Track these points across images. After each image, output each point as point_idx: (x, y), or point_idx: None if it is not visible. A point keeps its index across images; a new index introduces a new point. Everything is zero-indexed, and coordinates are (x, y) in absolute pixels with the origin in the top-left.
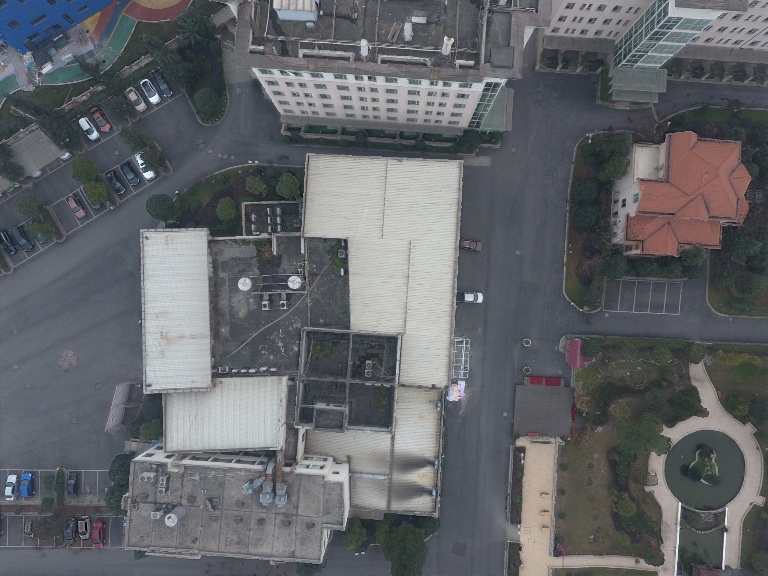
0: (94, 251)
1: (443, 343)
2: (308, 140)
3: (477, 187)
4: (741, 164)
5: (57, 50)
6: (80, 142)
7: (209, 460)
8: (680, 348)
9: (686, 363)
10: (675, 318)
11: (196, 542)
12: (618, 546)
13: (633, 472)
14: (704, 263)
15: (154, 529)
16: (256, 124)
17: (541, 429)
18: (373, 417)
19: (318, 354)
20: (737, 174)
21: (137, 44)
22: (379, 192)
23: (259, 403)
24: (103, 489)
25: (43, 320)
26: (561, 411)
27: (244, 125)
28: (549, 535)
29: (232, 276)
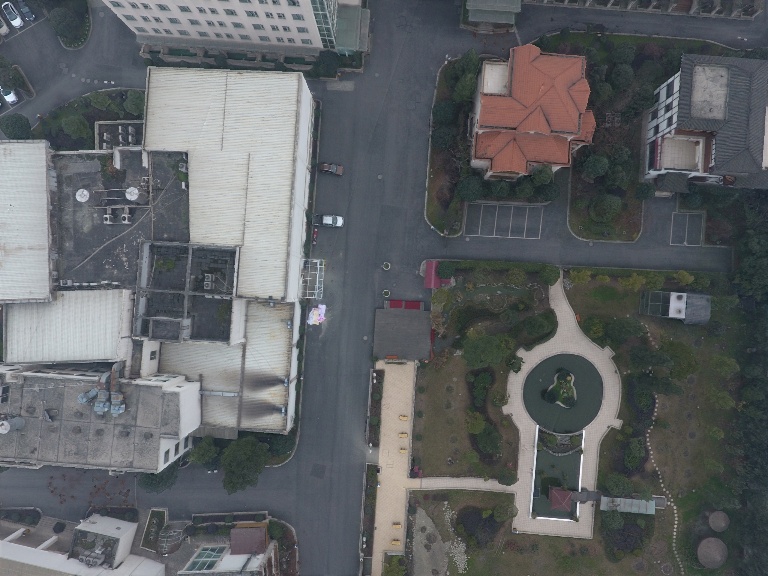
0: None
1: (280, 255)
2: (170, 64)
3: (340, 112)
4: (584, 78)
5: None
6: None
7: (51, 373)
8: (537, 271)
9: (546, 287)
10: (536, 243)
11: (35, 452)
12: (476, 468)
13: (491, 395)
14: (565, 188)
15: None
16: (119, 48)
17: (400, 352)
18: (215, 331)
19: (161, 268)
20: (577, 87)
21: None
22: (219, 105)
23: (100, 316)
24: None
25: None
26: (420, 334)
27: (107, 49)
28: (407, 457)
29: (76, 191)
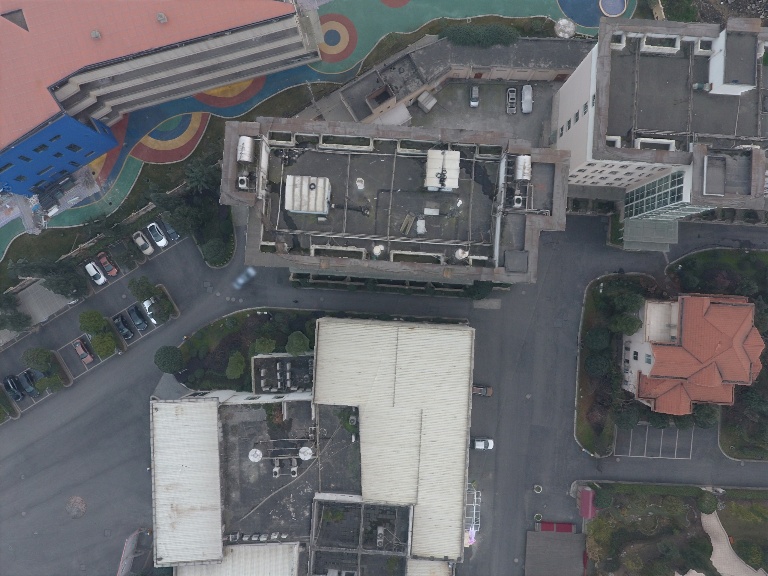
0: (102, 396)
1: (455, 514)
2: (317, 284)
3: (487, 330)
4: (754, 327)
5: (63, 192)
6: (87, 286)
7: None
8: (692, 496)
9: None
10: (687, 463)
11: None
12: None
13: None
14: None
15: None
16: (264, 267)
17: (552, 575)
18: None
19: (329, 520)
20: (750, 341)
21: (144, 187)
22: (390, 360)
23: (270, 572)
24: None
25: (51, 466)
26: (572, 558)
27: (252, 268)
28: None
29: (242, 440)
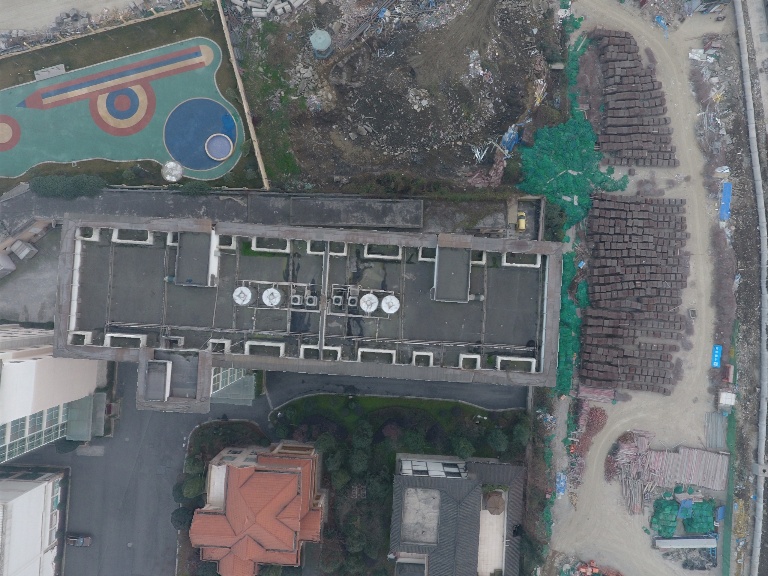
0: None
1: None
2: None
3: (90, 477)
4: (299, 495)
5: None
6: None
7: None
8: None
9: None
10: None
11: None
12: None
13: None
14: (316, 555)
15: None
16: None
17: None
18: None
19: None
20: (286, 512)
21: None
22: None
23: None
24: None
25: None
26: None
27: None
28: None
29: None
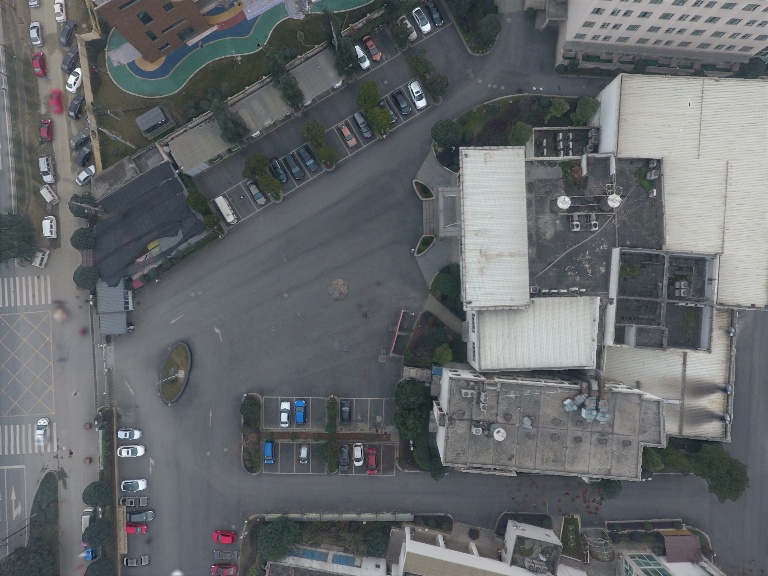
0: (363, 180)
1: (762, 263)
2: (581, 70)
3: None
4: None
5: None
6: None
7: None
8: None
9: None
10: None
11: (512, 459)
12: None
13: None
14: None
15: (470, 446)
16: (527, 54)
17: None
18: (681, 338)
19: (626, 275)
20: None
21: None
22: (695, 112)
23: (572, 323)
24: (374, 417)
25: (313, 249)
26: None
27: (514, 55)
28: None
29: (538, 197)
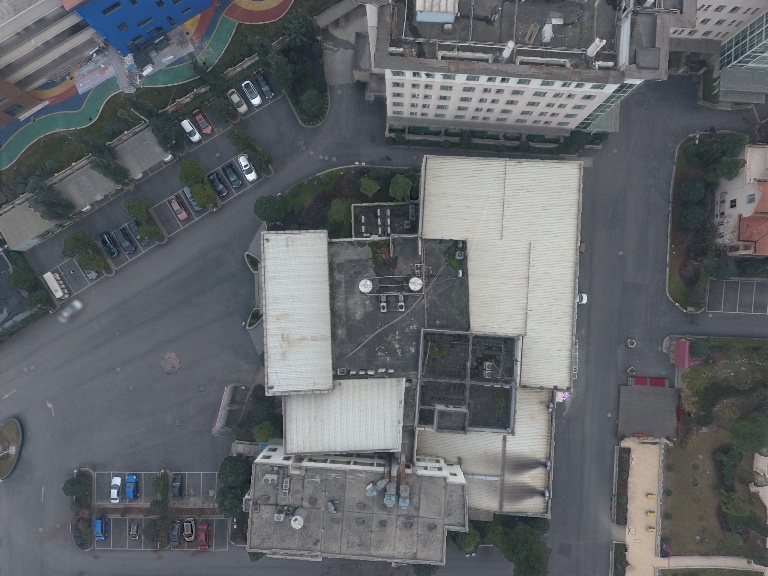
0: (196, 253)
1: (564, 344)
2: (410, 141)
3: None
4: None
5: (158, 52)
6: None
7: (328, 462)
8: None
9: None
10: None
11: (318, 544)
12: (724, 546)
13: (738, 472)
14: None
15: (275, 531)
16: (357, 125)
17: (646, 430)
18: (491, 418)
19: (435, 356)
20: None
21: (238, 46)
22: (498, 193)
23: (378, 405)
24: (207, 491)
25: (145, 322)
26: (666, 412)
27: (345, 127)
28: (655, 536)
29: (348, 278)
